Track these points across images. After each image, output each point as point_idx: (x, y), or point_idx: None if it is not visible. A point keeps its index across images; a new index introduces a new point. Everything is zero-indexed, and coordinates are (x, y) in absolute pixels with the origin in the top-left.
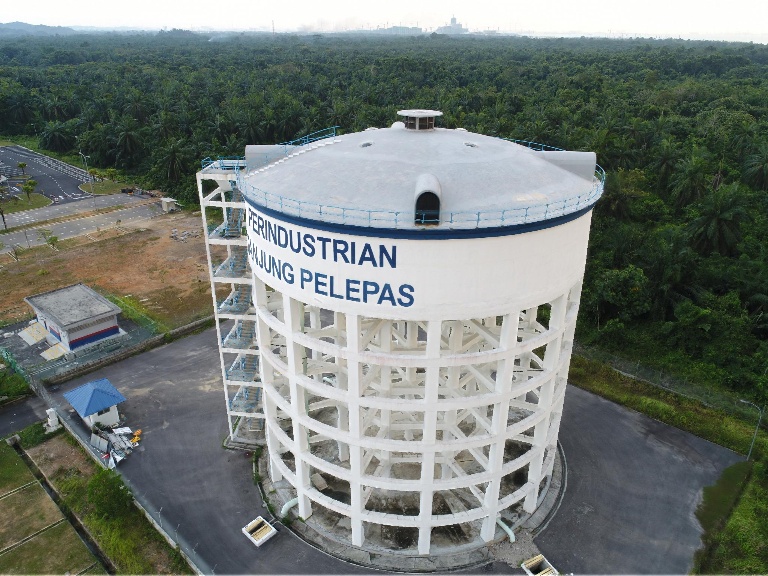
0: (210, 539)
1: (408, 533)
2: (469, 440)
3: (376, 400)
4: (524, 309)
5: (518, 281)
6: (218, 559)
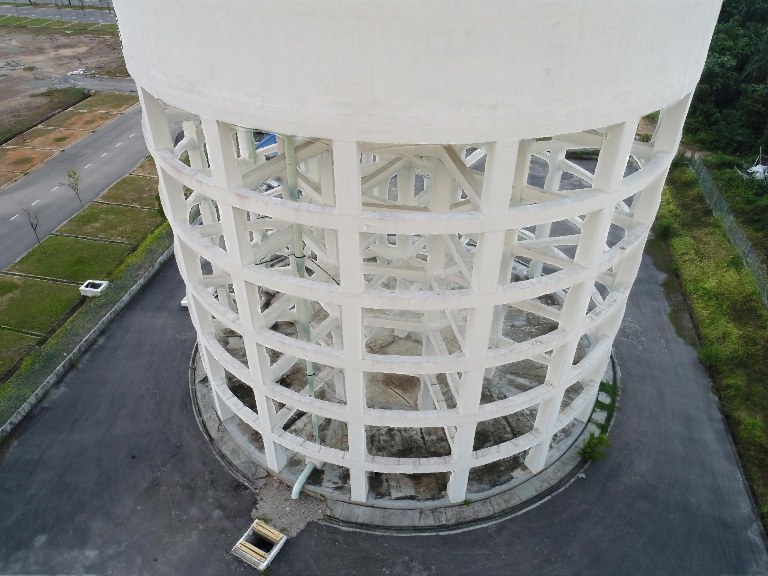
0: (178, 278)
1: (246, 393)
2: (214, 304)
3: (159, 186)
4: (224, 120)
5: (200, 54)
6: (158, 292)
